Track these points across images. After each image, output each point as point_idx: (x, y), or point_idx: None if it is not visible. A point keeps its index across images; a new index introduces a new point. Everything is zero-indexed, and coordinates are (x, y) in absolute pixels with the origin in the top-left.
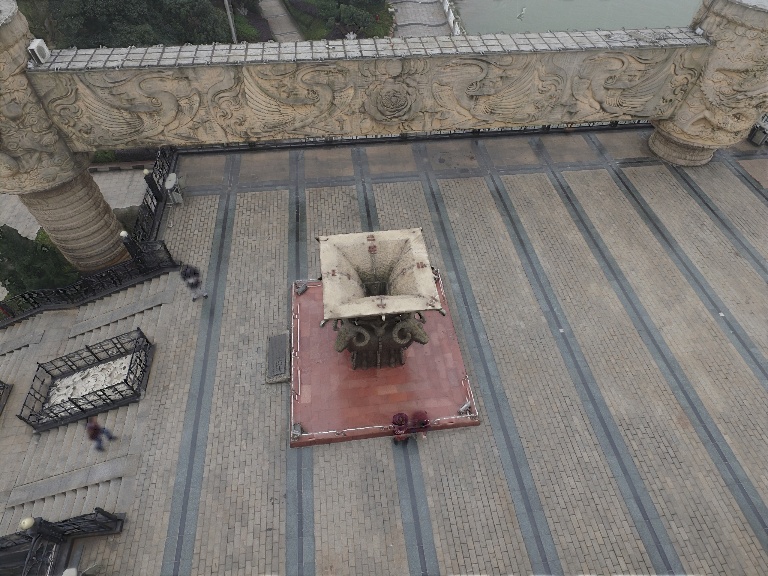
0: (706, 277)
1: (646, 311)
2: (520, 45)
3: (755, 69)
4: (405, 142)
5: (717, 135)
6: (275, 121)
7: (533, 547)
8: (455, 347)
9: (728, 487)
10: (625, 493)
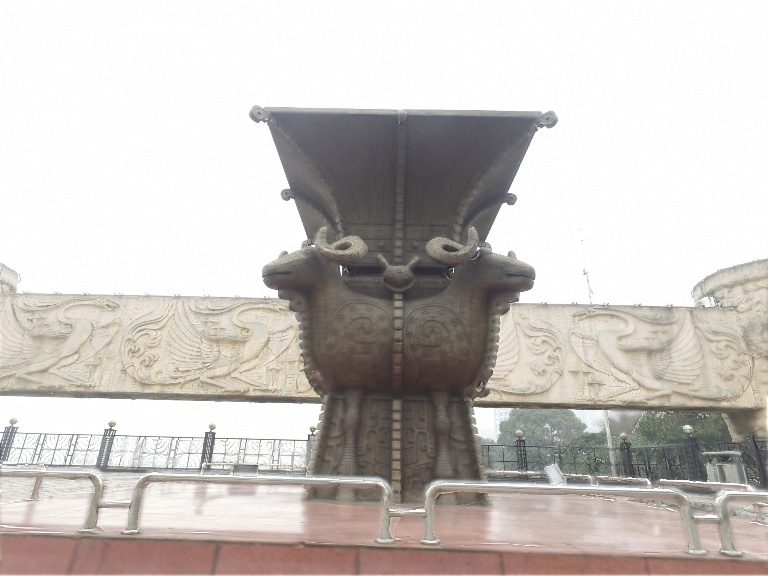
0: None
1: None
2: None
3: None
4: None
5: None
6: None
7: None
8: (167, 486)
9: None
10: None
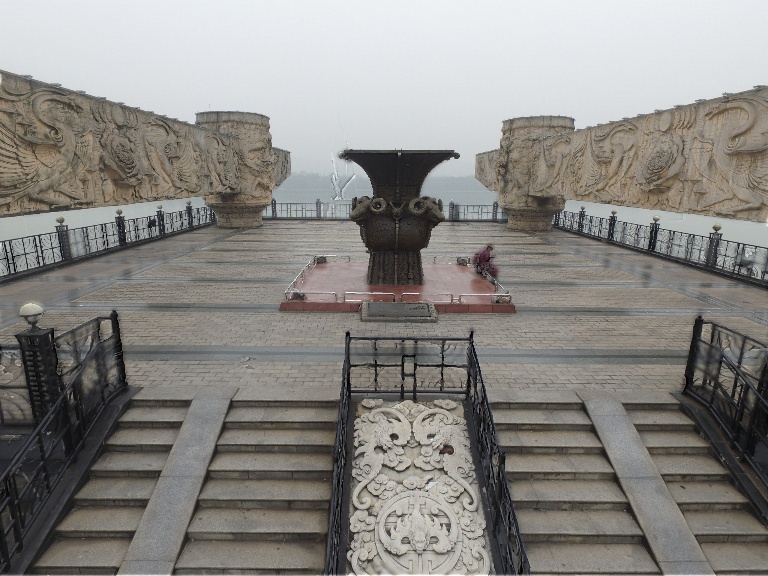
0: None
1: None
2: None
3: (264, 147)
4: (75, 264)
5: (268, 193)
6: (11, 176)
7: None
8: None
9: None
10: None
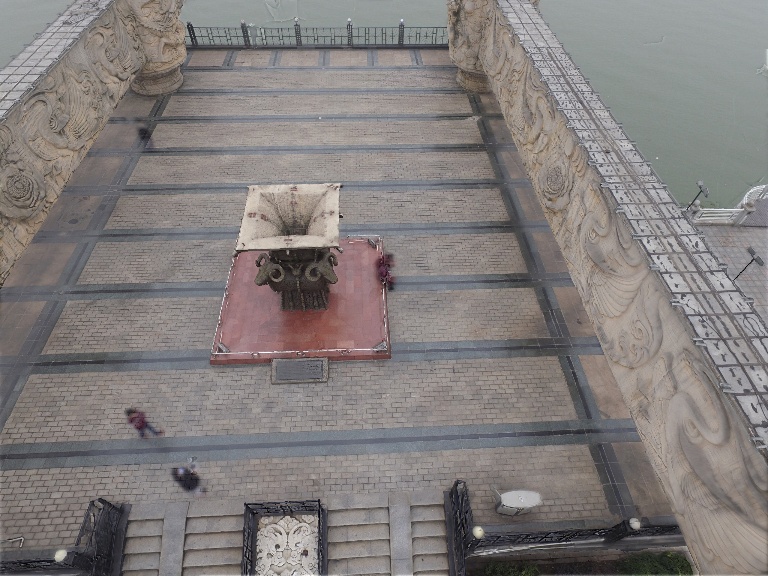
0: (289, 114)
1: (309, 146)
2: (38, 65)
3: None
4: None
5: (179, 51)
6: None
7: (458, 231)
8: None
9: (426, 152)
10: (429, 188)
